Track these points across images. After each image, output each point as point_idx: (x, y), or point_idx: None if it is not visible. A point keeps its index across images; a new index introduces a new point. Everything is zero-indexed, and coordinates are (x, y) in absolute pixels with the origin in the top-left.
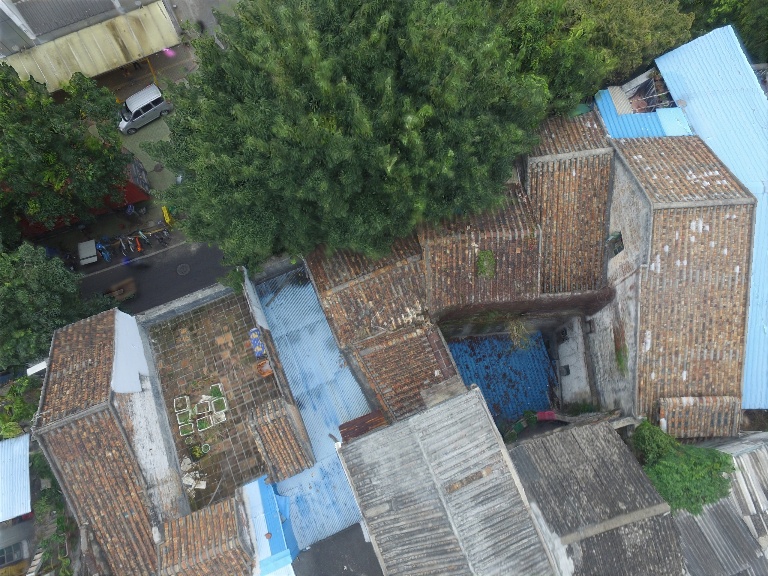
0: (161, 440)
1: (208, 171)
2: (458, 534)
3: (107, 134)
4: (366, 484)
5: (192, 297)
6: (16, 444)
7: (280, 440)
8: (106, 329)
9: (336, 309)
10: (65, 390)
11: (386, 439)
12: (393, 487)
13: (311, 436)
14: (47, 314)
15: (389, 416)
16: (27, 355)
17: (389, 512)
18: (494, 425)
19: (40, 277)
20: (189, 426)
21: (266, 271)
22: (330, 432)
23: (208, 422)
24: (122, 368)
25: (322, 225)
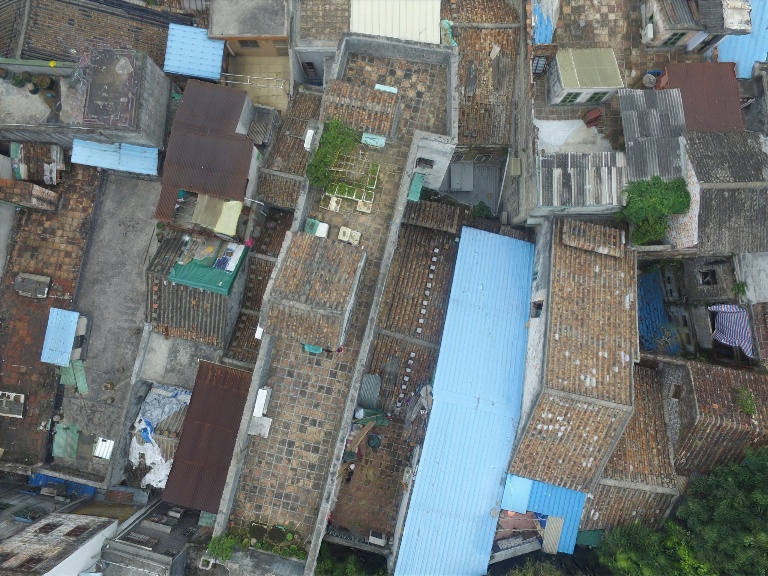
0: None
1: None
2: None
3: None
4: None
5: None
6: None
7: None
8: None
9: None
10: None
11: None
12: None
13: None
14: None
15: None
16: None
17: None
18: None
19: None
20: None
21: None
22: None
23: None
24: None
25: None
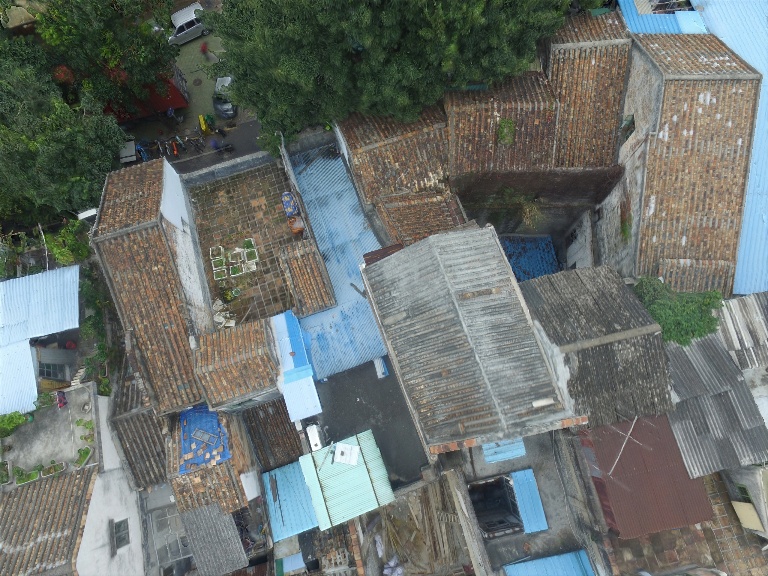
0: (198, 278)
1: (262, 10)
2: (467, 331)
3: (161, 16)
4: (386, 297)
5: (231, 161)
6: (67, 272)
7: (307, 275)
8: (155, 172)
9: (365, 167)
10: (118, 213)
11: (407, 256)
12: (411, 298)
13: (334, 284)
14: (99, 166)
15: None
16: (80, 201)
17: (405, 320)
18: (505, 257)
19: (97, 126)
20: (223, 272)
21: (300, 143)
22: (352, 282)
23: (240, 268)
24: (168, 203)
25: (359, 81)
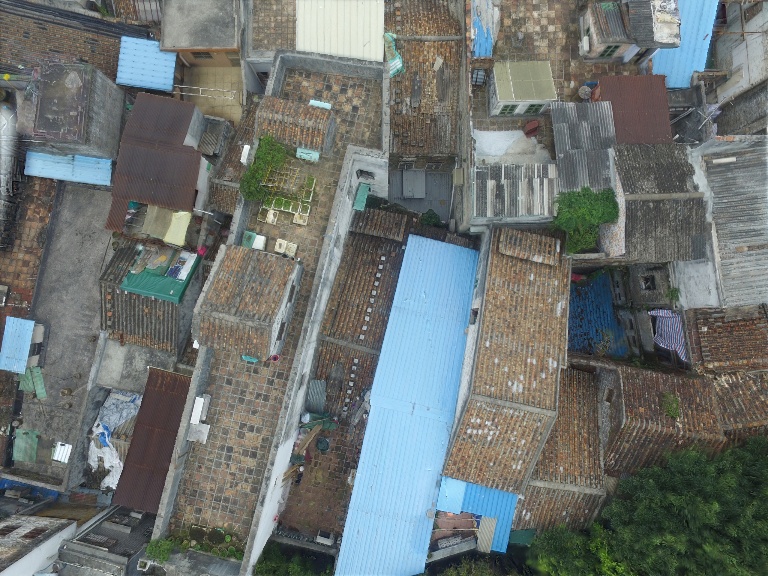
0: None
1: None
2: None
3: None
4: None
5: None
6: None
7: None
8: None
9: None
10: None
11: None
12: None
13: None
14: None
15: (767, 306)
16: None
17: None
18: (719, 279)
19: None
20: None
21: None
22: None
23: None
24: None
25: None
